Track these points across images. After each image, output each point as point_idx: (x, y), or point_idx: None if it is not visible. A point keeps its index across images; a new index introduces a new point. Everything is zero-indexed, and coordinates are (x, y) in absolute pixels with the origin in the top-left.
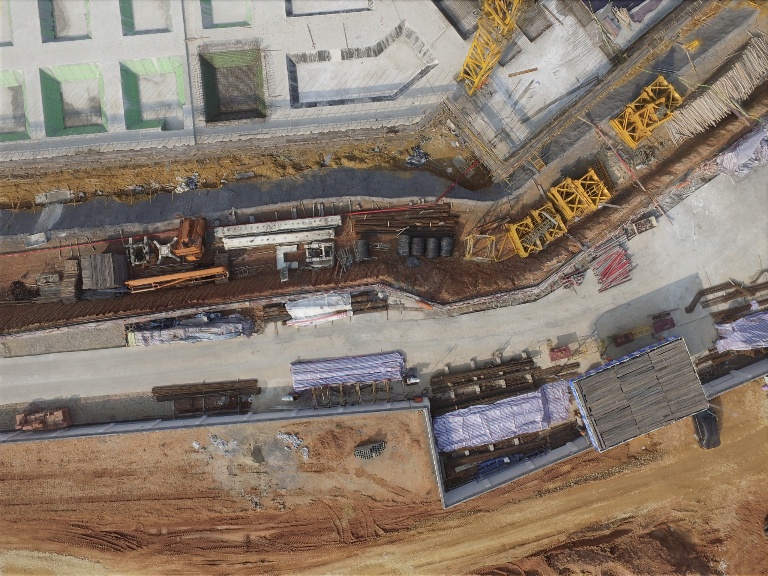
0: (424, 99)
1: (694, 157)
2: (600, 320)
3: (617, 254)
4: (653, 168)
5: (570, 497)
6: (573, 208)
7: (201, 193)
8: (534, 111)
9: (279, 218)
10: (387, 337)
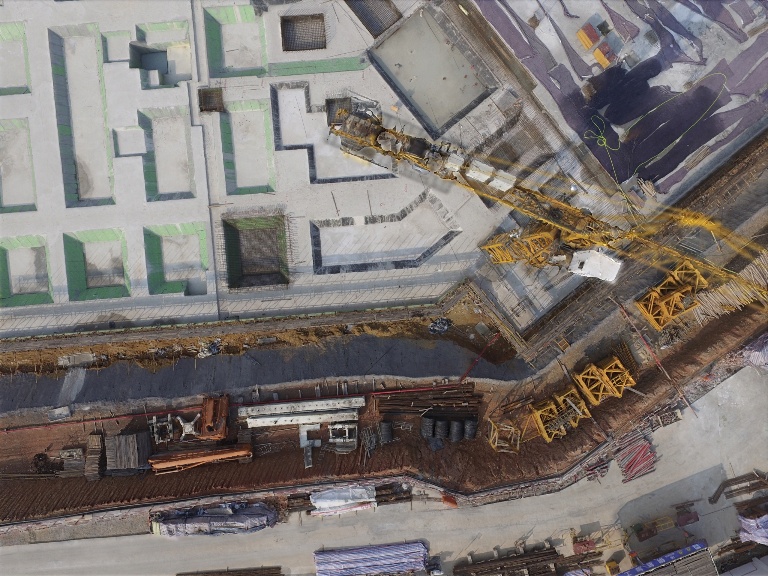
0: (447, 266)
1: (720, 347)
2: (623, 510)
3: (642, 447)
4: (678, 349)
5: None
6: (598, 396)
7: (224, 360)
8: (557, 279)
9: (303, 395)
10: (411, 527)
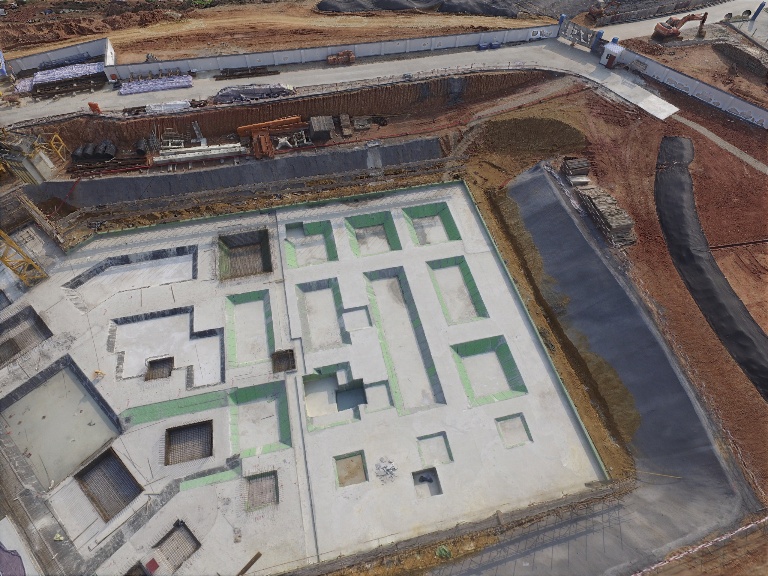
0: (81, 261)
1: None
2: None
3: None
4: None
5: None
6: None
7: None
8: None
9: (203, 163)
10: (128, 100)
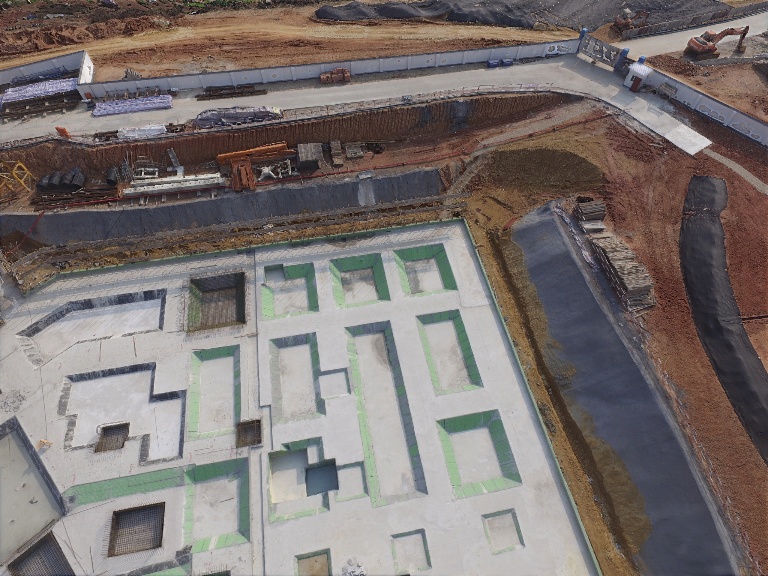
0: (41, 305)
1: None
2: None
3: None
4: None
5: None
6: None
7: None
8: None
9: (177, 195)
10: (101, 123)
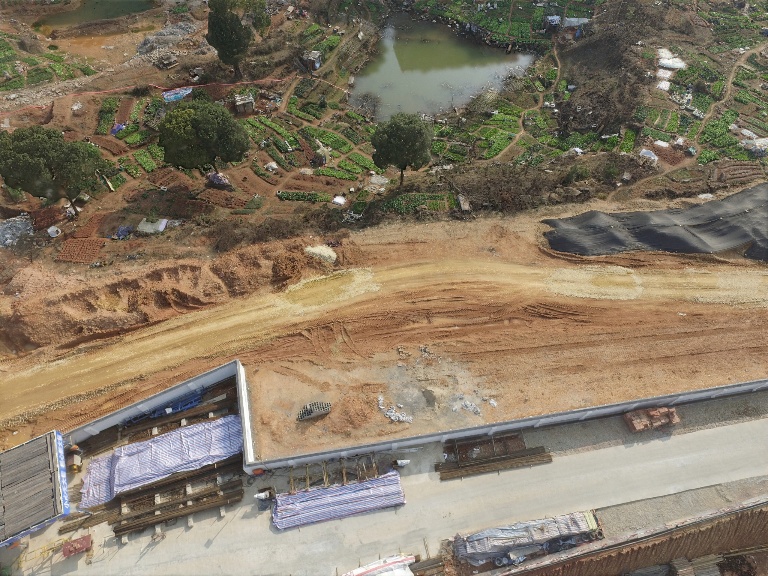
0: None
1: None
2: None
3: None
4: None
5: (111, 376)
6: None
7: None
8: None
9: None
10: (292, 550)
